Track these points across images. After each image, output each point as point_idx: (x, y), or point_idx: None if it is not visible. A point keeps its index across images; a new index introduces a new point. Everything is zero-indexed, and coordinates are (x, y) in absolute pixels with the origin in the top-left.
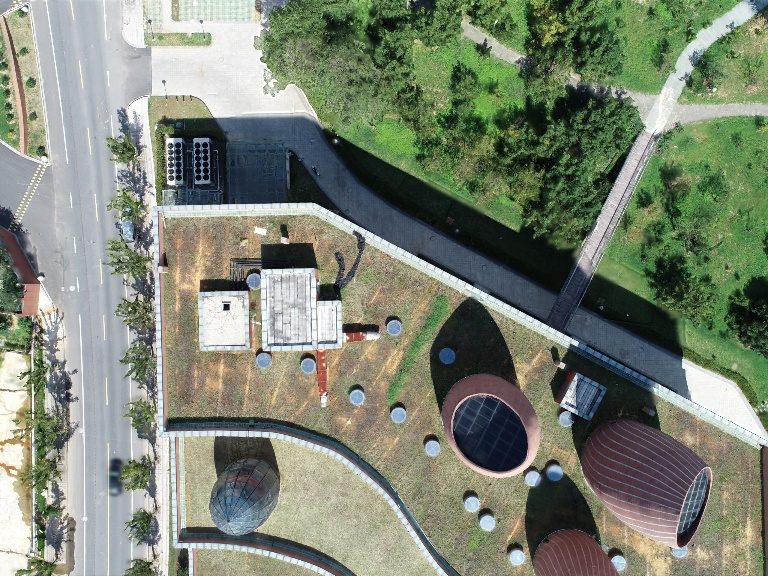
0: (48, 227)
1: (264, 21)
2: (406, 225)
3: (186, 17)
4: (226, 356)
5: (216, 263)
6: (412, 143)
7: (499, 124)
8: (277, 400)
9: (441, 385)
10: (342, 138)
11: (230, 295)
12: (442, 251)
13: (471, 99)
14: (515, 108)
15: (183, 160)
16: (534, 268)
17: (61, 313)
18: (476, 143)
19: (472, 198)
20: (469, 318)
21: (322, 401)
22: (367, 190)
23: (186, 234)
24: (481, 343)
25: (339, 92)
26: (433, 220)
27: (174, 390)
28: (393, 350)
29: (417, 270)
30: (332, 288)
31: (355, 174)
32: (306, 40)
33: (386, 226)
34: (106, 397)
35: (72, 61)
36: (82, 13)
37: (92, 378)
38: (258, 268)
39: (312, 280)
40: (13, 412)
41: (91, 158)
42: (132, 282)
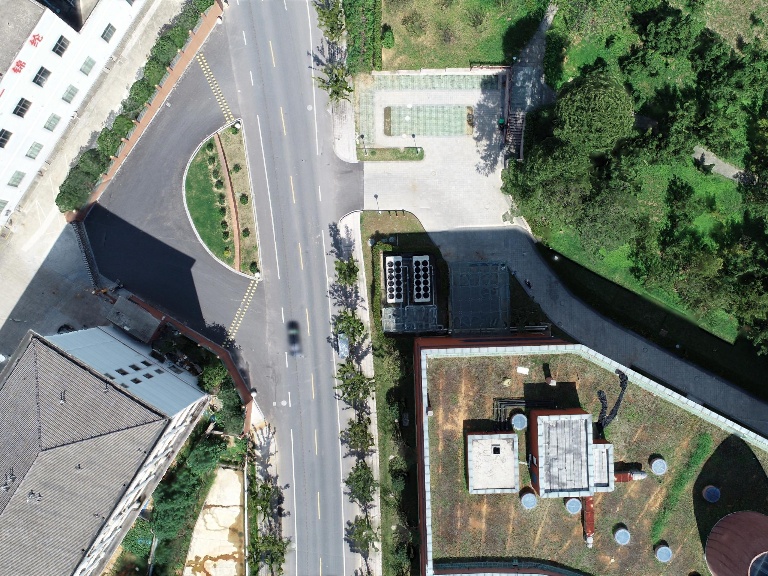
0: (260, 342)
1: (476, 135)
2: (618, 337)
3: (398, 132)
4: (489, 496)
5: (479, 403)
6: (626, 256)
7: (715, 238)
8: (540, 539)
9: (704, 522)
10: (555, 251)
11: (499, 438)
12: (655, 363)
13: (694, 216)
14: (732, 222)
15: (402, 278)
16: (748, 379)
17: (273, 428)
18: (706, 264)
19: (688, 311)
20: (731, 455)
21: (589, 542)
22: (579, 302)
23: (448, 374)
24: (744, 480)
25: (604, 232)
26: (648, 333)
27: (437, 530)
28: (656, 488)
29: (679, 407)
30: (595, 427)
31: (569, 287)
32: (578, 185)
33: (599, 338)
34: (318, 511)
35: (284, 176)
36: (294, 128)
37: (304, 493)
38: (521, 407)
39: (589, 426)
40: (226, 528)
41: (303, 273)
42: (344, 396)
